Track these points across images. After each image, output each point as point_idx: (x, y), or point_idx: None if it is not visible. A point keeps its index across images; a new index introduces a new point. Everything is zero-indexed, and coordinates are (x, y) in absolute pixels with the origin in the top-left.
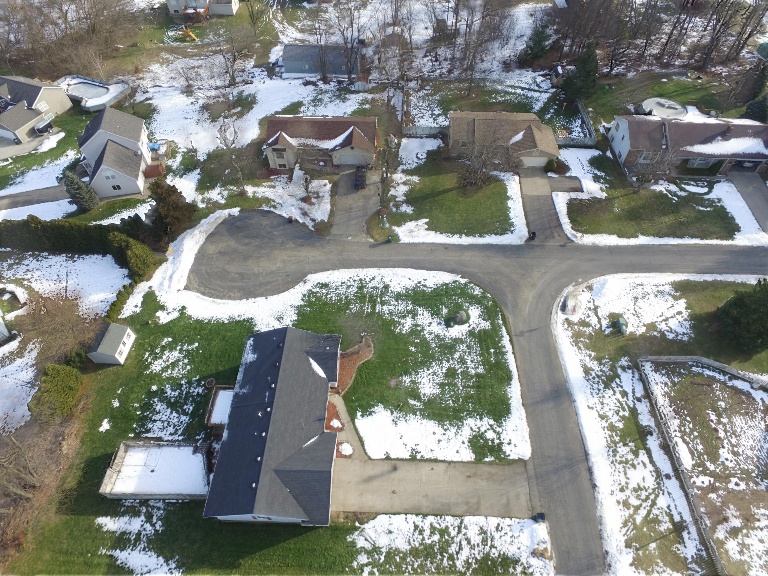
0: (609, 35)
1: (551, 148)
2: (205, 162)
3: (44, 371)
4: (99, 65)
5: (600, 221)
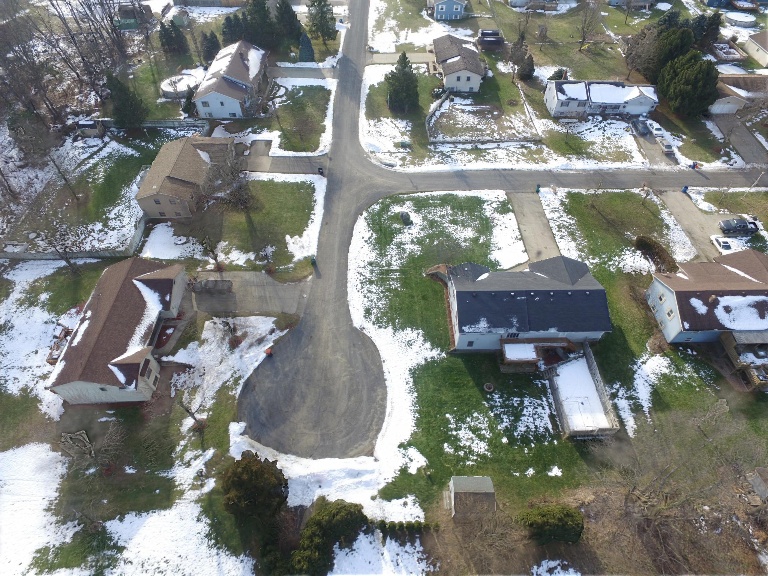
0: None
1: (226, 139)
2: None
3: (541, 529)
4: None
5: (306, 138)
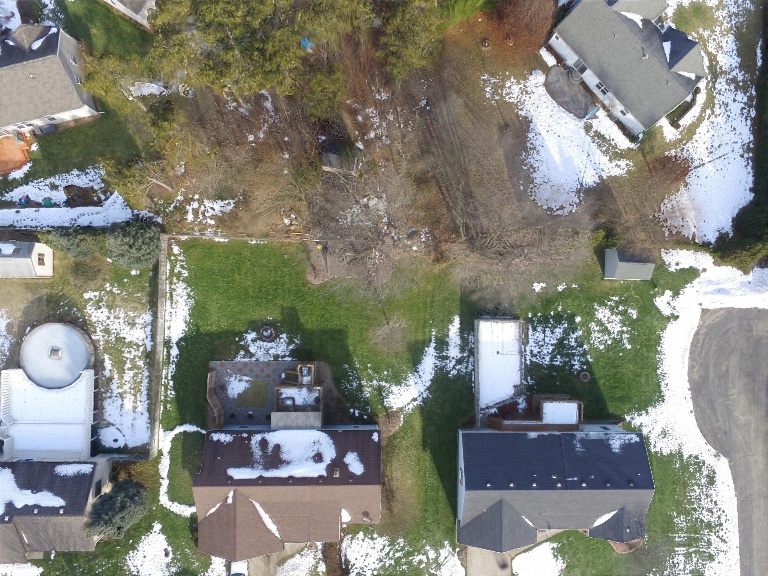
0: None
1: None
2: None
3: (596, 226)
4: None
5: None
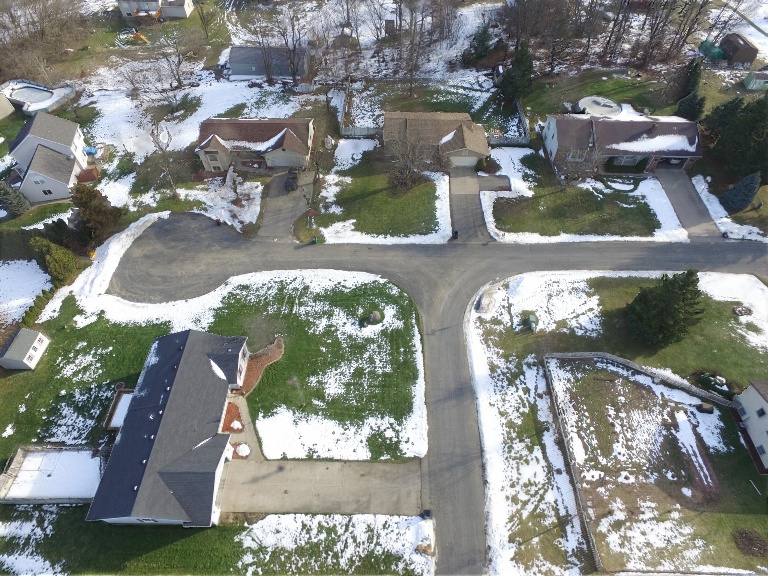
0: (556, 34)
1: (480, 147)
2: (142, 165)
3: None
4: (44, 69)
5: (524, 219)
